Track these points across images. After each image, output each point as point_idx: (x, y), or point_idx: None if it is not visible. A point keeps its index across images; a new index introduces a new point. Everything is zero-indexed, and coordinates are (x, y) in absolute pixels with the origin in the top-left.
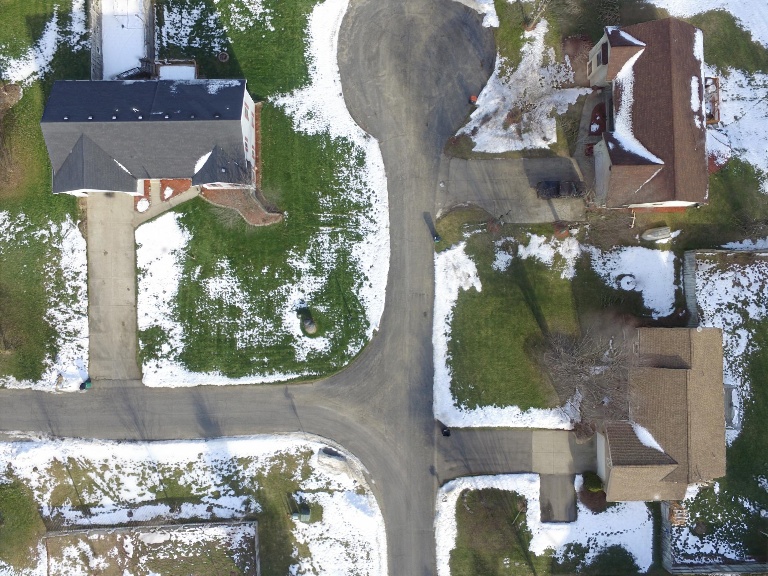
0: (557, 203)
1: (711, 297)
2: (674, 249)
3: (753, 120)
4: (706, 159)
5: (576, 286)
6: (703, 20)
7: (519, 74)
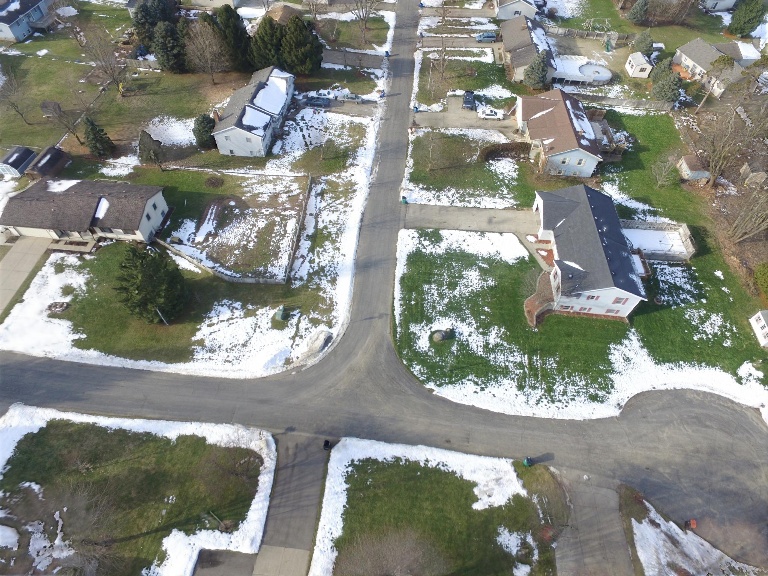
0: None
1: None
2: None
3: None
4: None
5: None
6: None
7: None
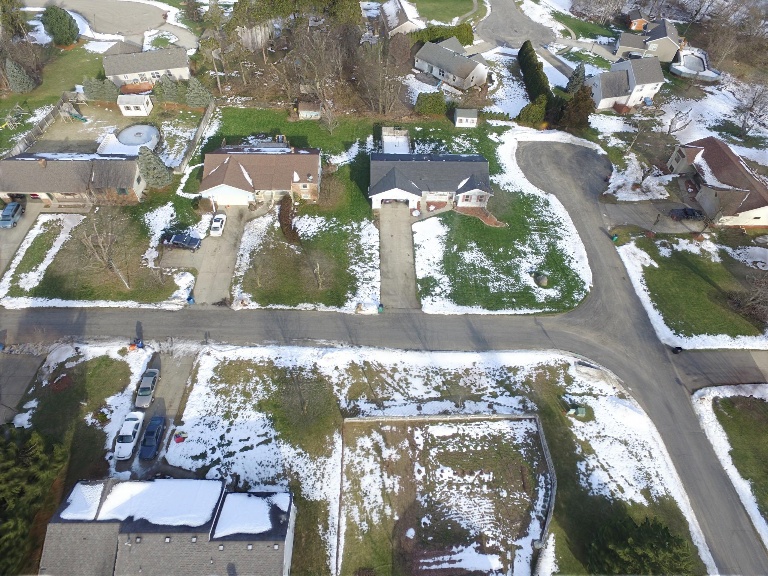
0: (687, 223)
1: None
2: None
3: None
4: None
5: (726, 266)
6: None
7: (629, 171)
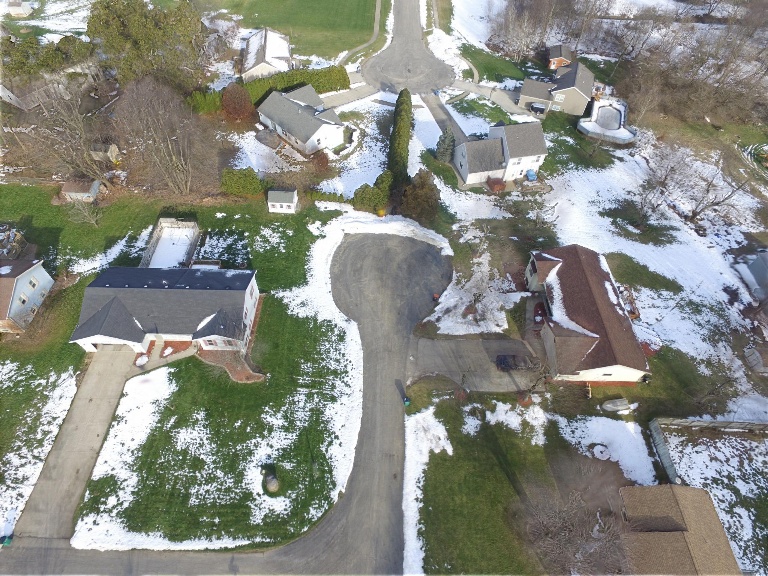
0: (517, 375)
1: (692, 470)
2: (638, 421)
3: (672, 321)
4: (637, 338)
5: (549, 453)
6: (607, 258)
7: (472, 283)
